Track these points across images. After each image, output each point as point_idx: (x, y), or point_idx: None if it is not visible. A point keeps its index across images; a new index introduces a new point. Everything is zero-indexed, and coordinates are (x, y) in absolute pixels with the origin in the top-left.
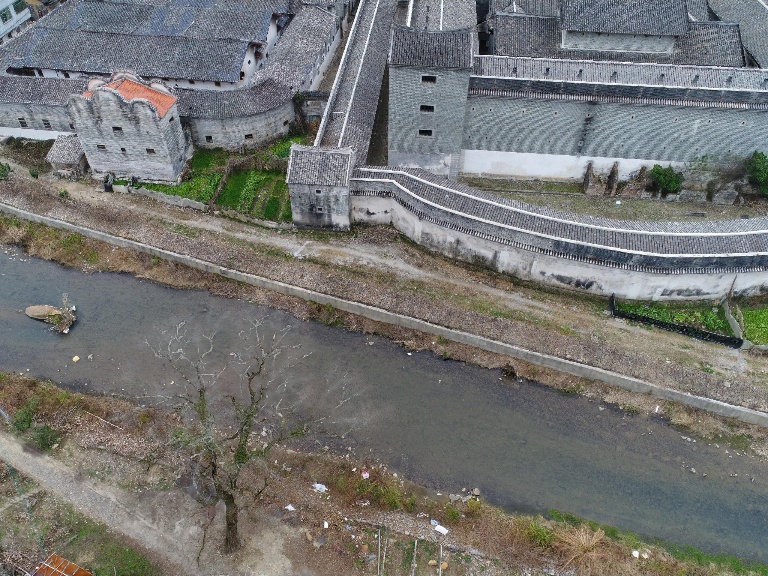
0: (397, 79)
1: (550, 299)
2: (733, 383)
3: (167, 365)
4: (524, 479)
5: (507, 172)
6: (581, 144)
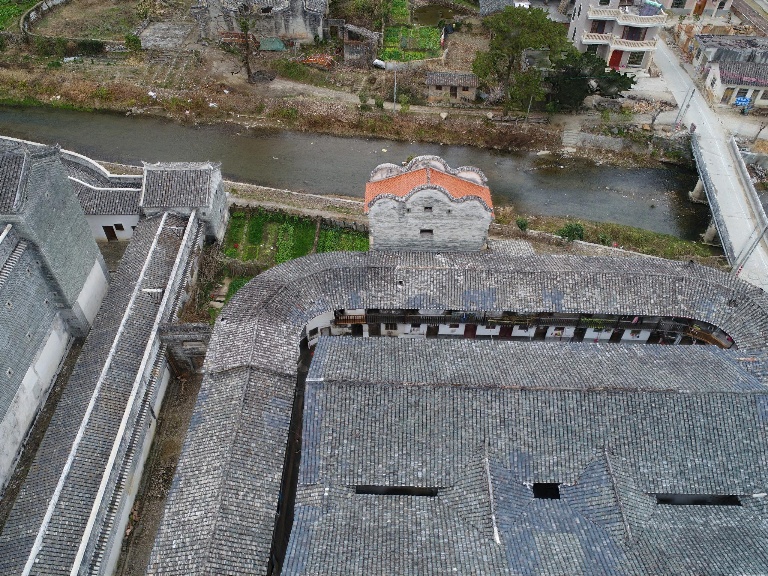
0: None
1: None
2: None
3: (320, 151)
4: (98, 121)
5: None
6: None
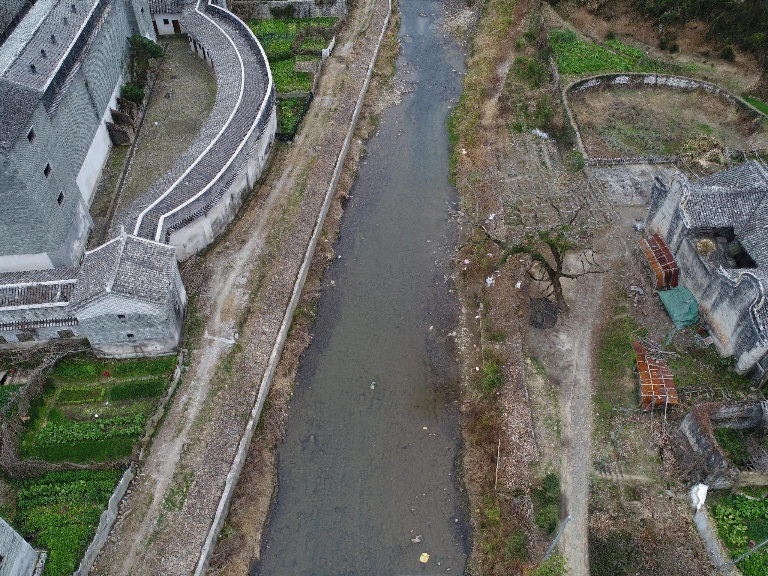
0: (19, 161)
1: (280, 166)
2: (343, 103)
3: (404, 444)
4: (432, 195)
5: (93, 183)
6: (95, 111)
